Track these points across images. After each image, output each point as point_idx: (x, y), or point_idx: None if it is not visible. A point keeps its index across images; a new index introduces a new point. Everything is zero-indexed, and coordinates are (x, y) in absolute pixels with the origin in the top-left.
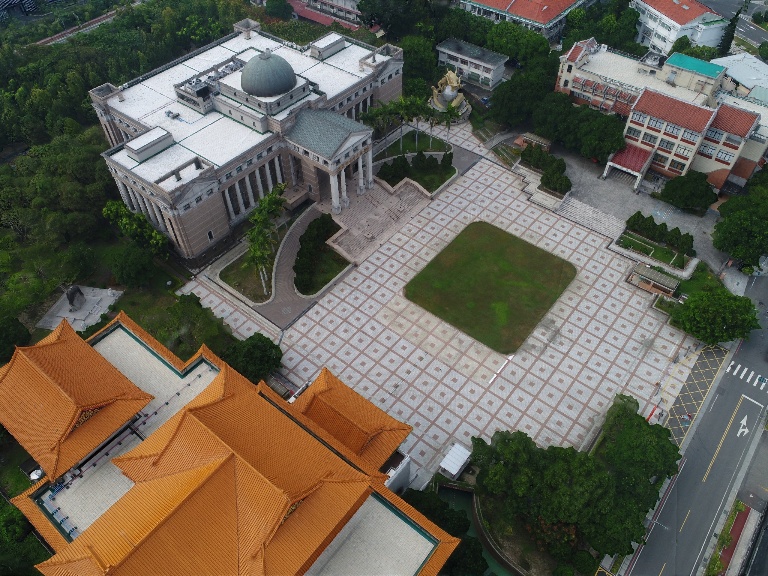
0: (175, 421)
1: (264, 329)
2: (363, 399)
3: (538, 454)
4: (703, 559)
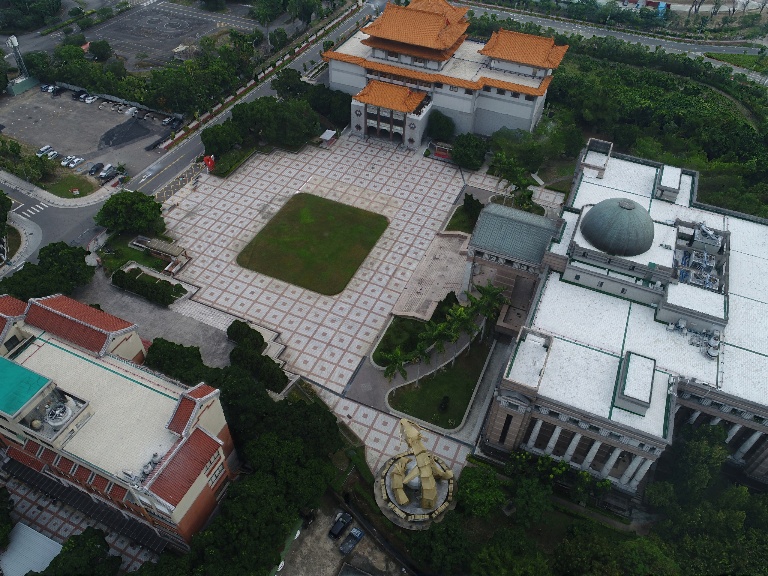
0: (455, 35)
1: (480, 183)
2: (384, 106)
3: (284, 113)
4: (199, 132)
